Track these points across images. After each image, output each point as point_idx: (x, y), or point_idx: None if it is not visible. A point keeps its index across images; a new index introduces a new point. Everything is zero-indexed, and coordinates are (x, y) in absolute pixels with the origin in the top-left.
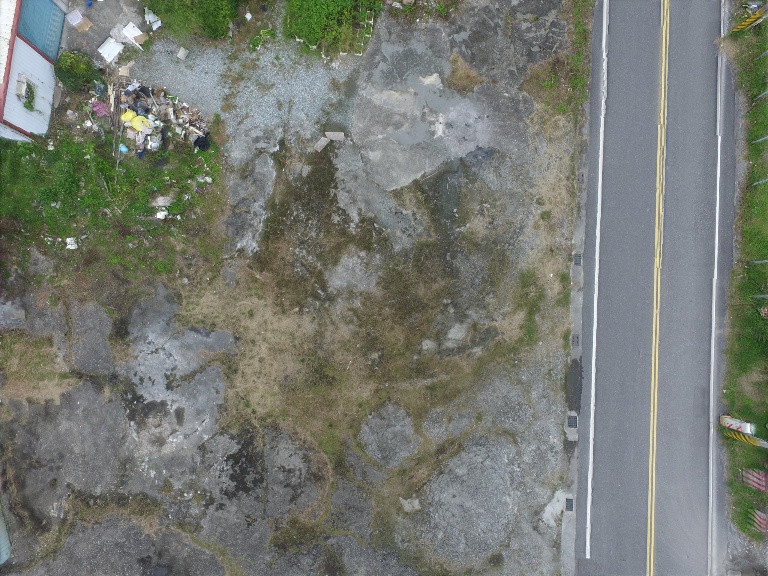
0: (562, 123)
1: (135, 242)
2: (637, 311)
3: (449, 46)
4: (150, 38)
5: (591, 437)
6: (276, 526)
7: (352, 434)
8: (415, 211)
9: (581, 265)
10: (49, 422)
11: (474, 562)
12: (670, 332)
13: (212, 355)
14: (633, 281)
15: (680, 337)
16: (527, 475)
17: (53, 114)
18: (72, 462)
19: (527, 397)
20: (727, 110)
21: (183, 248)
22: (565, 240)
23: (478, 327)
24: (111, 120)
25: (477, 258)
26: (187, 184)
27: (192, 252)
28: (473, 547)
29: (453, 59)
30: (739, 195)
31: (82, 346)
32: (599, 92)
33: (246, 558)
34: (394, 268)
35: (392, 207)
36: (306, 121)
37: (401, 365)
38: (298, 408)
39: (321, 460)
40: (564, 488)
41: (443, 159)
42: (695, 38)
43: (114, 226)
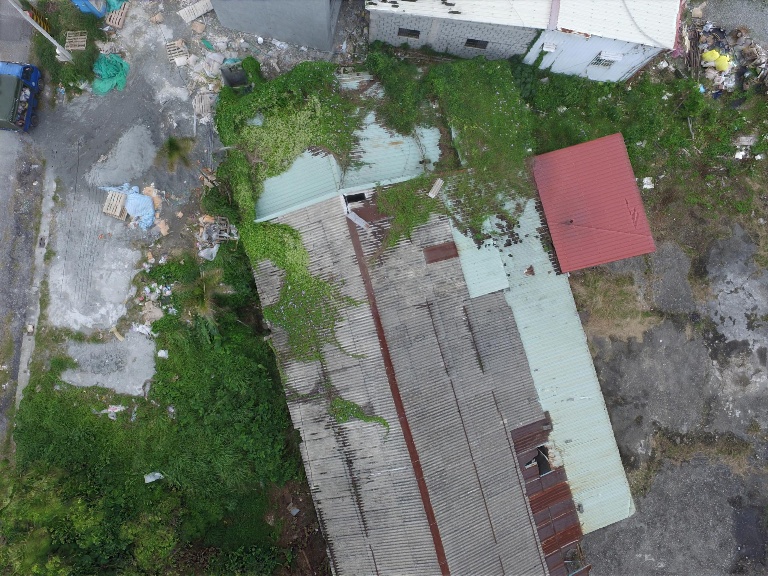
0: None
1: (713, 182)
2: None
3: None
4: None
5: None
6: None
7: None
8: None
9: None
10: (633, 360)
11: None
12: None
13: None
14: None
15: None
16: None
17: None
18: (657, 400)
19: None
20: None
21: (759, 188)
22: None
23: None
24: (687, 61)
25: None
26: (764, 124)
27: (767, 192)
28: None
29: None
30: None
31: (662, 285)
32: None
33: None
34: None
35: None
36: None
37: None
38: None
39: None
40: None
41: None
42: None
43: (695, 165)
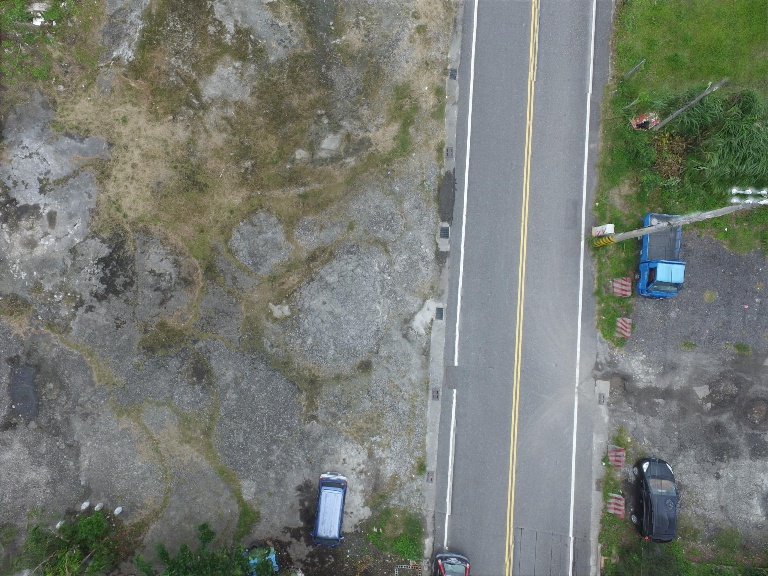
0: None
1: (11, 48)
2: (511, 124)
3: None
4: None
5: (462, 247)
6: (145, 329)
7: (223, 240)
8: (291, 23)
9: (456, 79)
10: None
11: (342, 368)
12: (543, 145)
13: (85, 160)
14: (507, 94)
15: (553, 150)
16: (397, 283)
17: None
18: None
19: (399, 207)
20: None
21: (59, 55)
22: (441, 54)
23: (352, 138)
24: None
25: (352, 70)
26: None
27: (68, 60)
28: (342, 353)
29: None
30: (616, 12)
31: None
32: None
33: (114, 359)
34: (269, 79)
35: (268, 19)
36: None
37: (274, 174)
38: (170, 214)
39: (192, 265)
40: (434, 297)
41: None
42: None
43: None
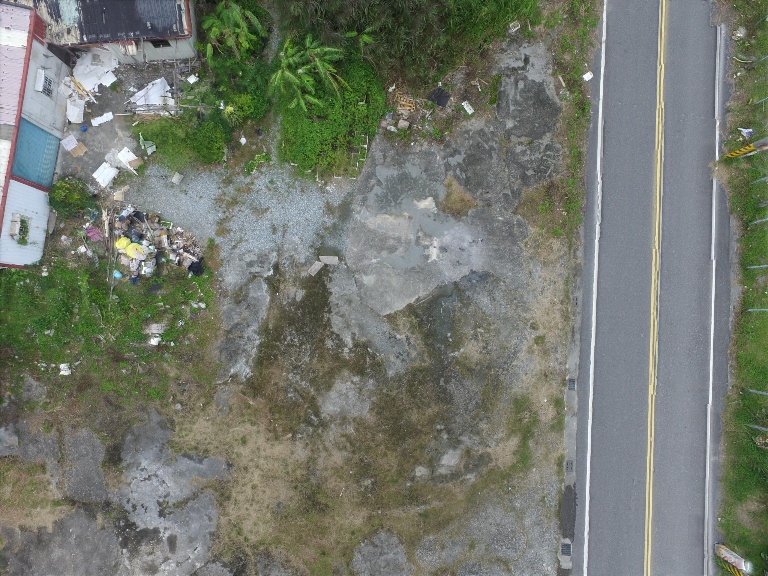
0: (556, 247)
1: (128, 368)
2: (631, 438)
3: (443, 169)
4: (145, 163)
5: (585, 565)
6: None
7: (345, 562)
8: (409, 336)
9: (575, 390)
10: (41, 550)
11: None
12: (664, 459)
13: (205, 482)
14: (627, 407)
15: (674, 464)
16: None
17: (48, 240)
18: None
19: (521, 524)
20: (722, 233)
21: (176, 374)
22: (559, 365)
23: (472, 453)
24: (105, 246)
25: (471, 383)
26: (181, 310)
27: (185, 377)
28: None
29: (447, 183)
30: (734, 320)
31: (75, 473)
32: (594, 215)
33: None
34: (388, 393)
35: (386, 332)
36: (300, 245)
37: (394, 492)
38: (291, 535)
39: None
40: None
41: (437, 283)
42: (690, 161)
43: (108, 353)
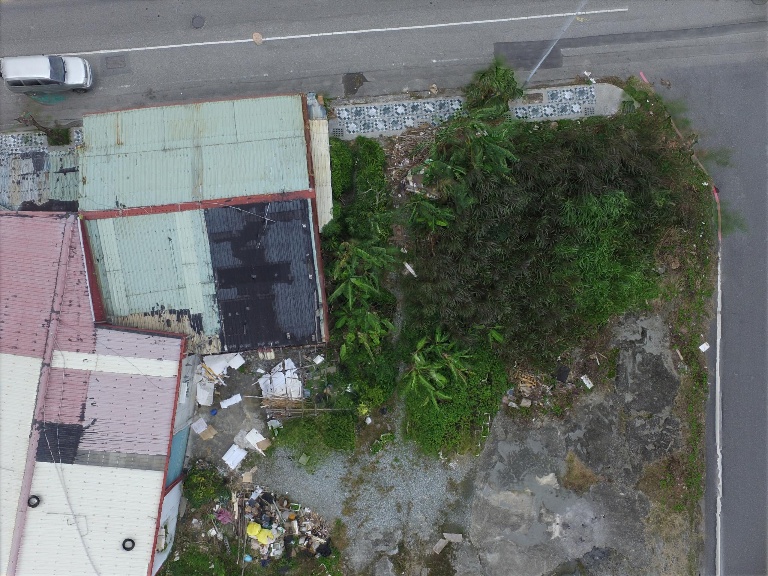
0: (678, 522)
1: None
2: None
3: (565, 445)
4: (272, 444)
5: None
6: None
7: None
8: None
9: None
10: None
11: None
12: None
13: None
14: None
15: None
16: None
17: (178, 523)
18: None
19: None
20: None
21: None
22: None
23: None
24: (235, 529)
25: None
26: None
27: None
28: None
29: (569, 459)
30: None
31: None
32: (714, 488)
33: None
34: None
35: None
36: (425, 522)
37: None
38: None
39: None
40: None
41: (561, 560)
42: None
43: None
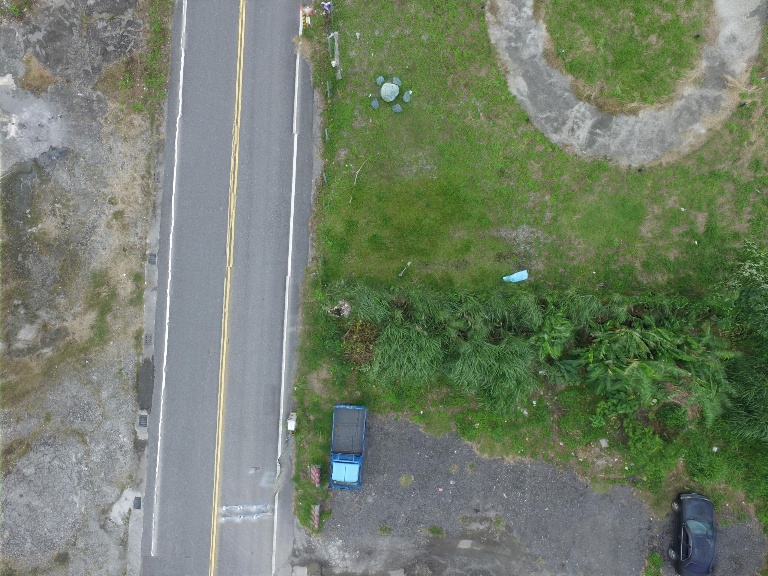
0: (137, 122)
1: None
2: (208, 310)
3: (23, 46)
4: None
5: None
6: None
7: None
8: None
9: (155, 264)
10: None
11: (39, 561)
12: (241, 330)
13: None
14: (205, 280)
15: (251, 335)
16: (95, 474)
17: None
18: None
19: (97, 397)
20: (305, 108)
21: None
22: (139, 240)
23: (49, 327)
24: None
25: (49, 259)
26: None
27: None
28: (39, 546)
29: (26, 59)
30: (315, 193)
31: None
32: (177, 91)
33: None
34: None
35: None
36: None
37: None
38: None
39: None
40: (133, 486)
41: (16, 160)
42: (274, 36)
43: None
